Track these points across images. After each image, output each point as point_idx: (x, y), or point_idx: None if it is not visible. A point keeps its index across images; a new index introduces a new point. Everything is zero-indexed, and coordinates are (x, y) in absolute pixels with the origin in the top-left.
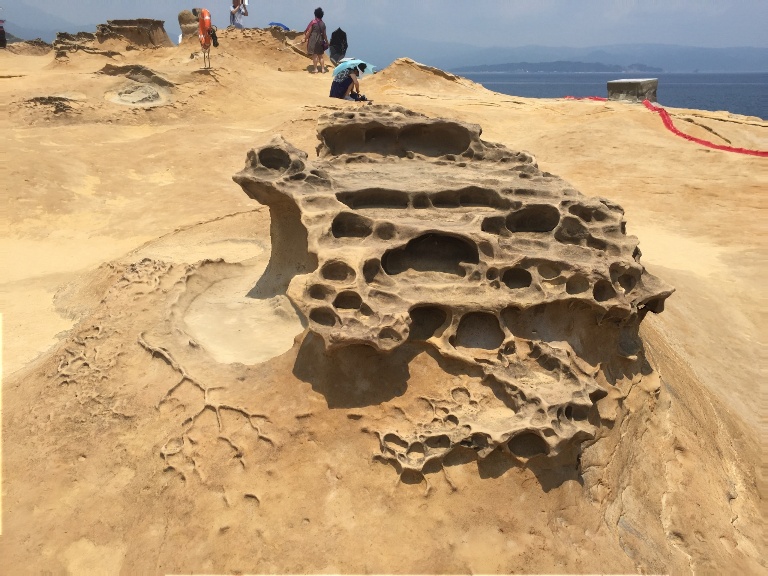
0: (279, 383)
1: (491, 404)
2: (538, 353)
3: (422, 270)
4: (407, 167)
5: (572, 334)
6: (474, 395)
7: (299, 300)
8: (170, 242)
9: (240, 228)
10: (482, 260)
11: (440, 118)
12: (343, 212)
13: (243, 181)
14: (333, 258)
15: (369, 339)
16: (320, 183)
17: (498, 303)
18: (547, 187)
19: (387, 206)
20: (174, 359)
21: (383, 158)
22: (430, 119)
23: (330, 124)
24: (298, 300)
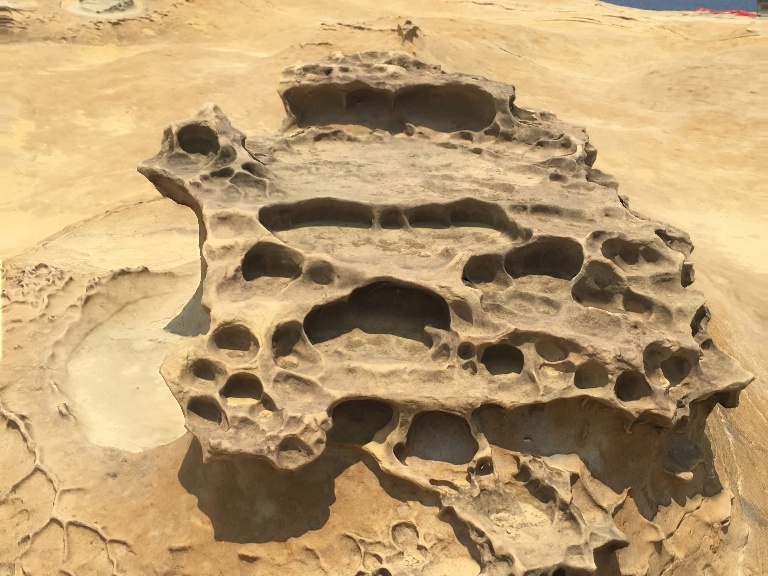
0: (158, 490)
1: (449, 552)
2: (527, 476)
3: (374, 332)
4: (398, 151)
5: (586, 444)
6: (424, 536)
7: (173, 383)
8: (95, 230)
9: (193, 212)
10: (453, 329)
11: (458, 75)
12: (262, 242)
13: (151, 174)
14: (230, 319)
15: (262, 454)
16: (253, 184)
17: (466, 401)
18: (583, 201)
19: (344, 223)
20: (32, 434)
21: (369, 135)
22: (440, 78)
23: (296, 83)
24: (172, 383)
